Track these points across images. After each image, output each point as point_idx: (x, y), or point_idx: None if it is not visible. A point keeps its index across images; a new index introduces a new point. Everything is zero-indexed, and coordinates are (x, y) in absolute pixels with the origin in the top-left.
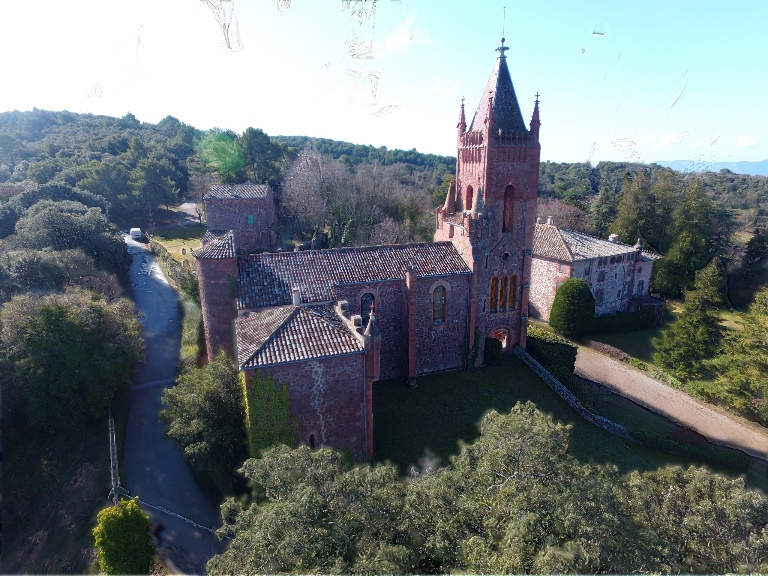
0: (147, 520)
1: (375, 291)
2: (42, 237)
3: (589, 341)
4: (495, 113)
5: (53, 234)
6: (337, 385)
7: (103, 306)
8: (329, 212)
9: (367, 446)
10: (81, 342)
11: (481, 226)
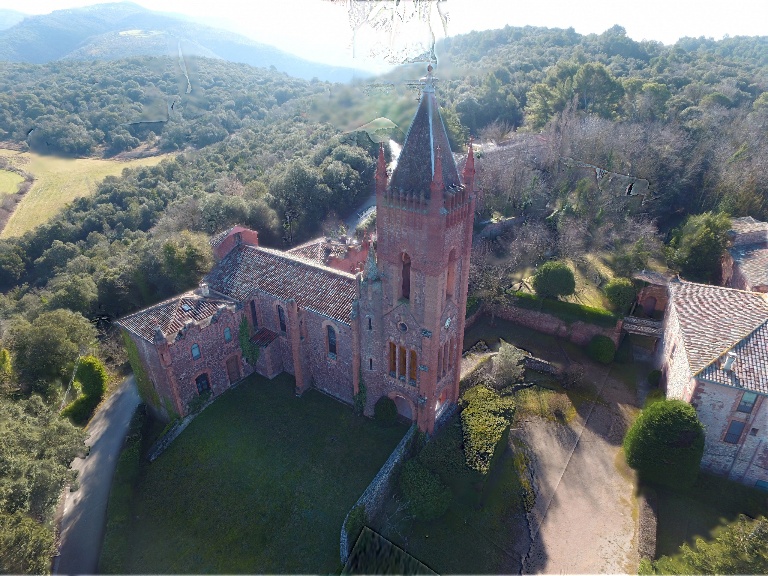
0: (94, 371)
1: (283, 306)
2: (281, 183)
3: (641, 497)
4: (400, 164)
5: (287, 182)
6: (154, 358)
7: (199, 250)
8: (545, 191)
9: (176, 406)
10: (184, 267)
11: (359, 286)
